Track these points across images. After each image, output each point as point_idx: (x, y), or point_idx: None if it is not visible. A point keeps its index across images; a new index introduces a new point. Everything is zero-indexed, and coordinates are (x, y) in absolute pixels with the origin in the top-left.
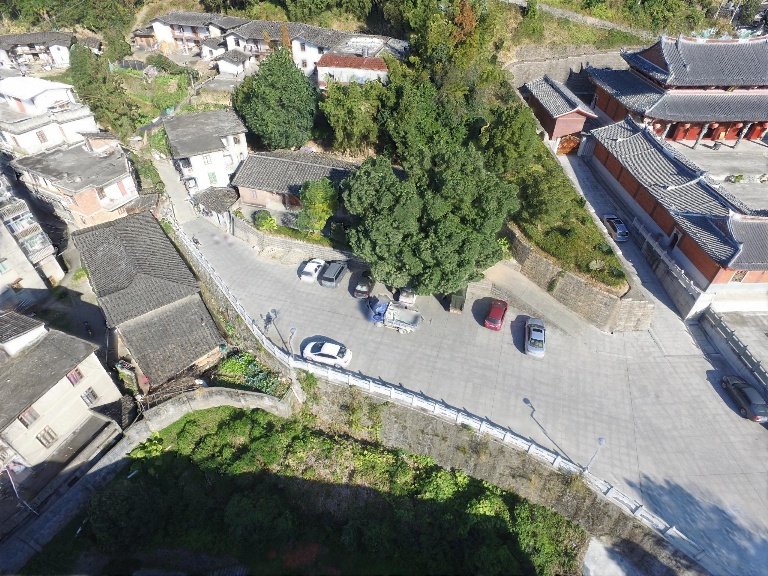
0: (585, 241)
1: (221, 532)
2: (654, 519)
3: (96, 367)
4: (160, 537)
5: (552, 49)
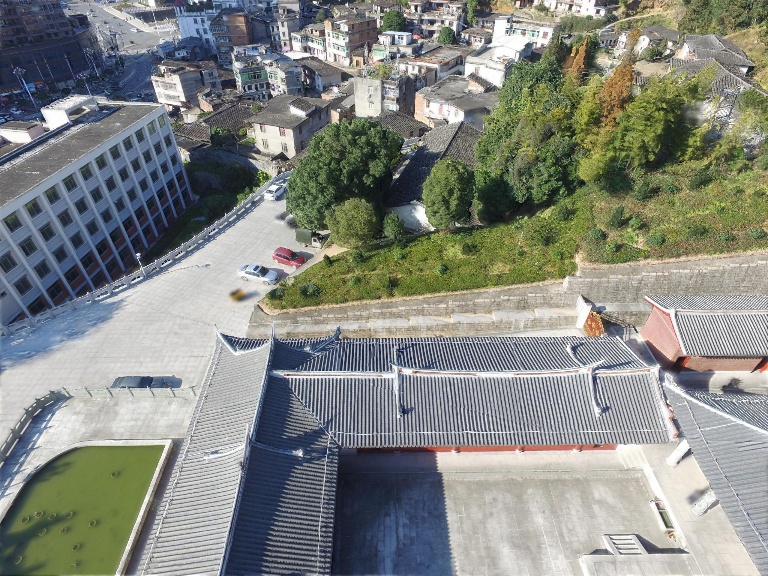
0: None
1: None
2: (99, 291)
3: (291, 138)
4: (228, 195)
5: None
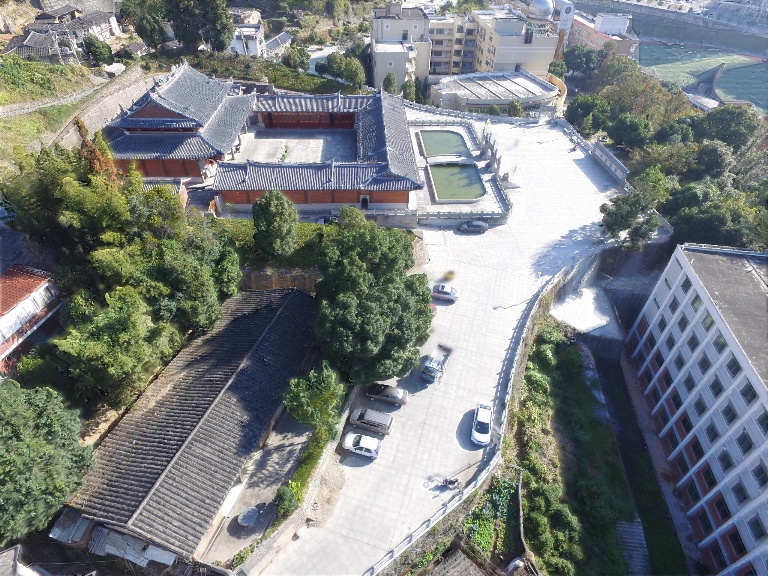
0: None
1: (606, 543)
2: None
3: None
4: None
5: None
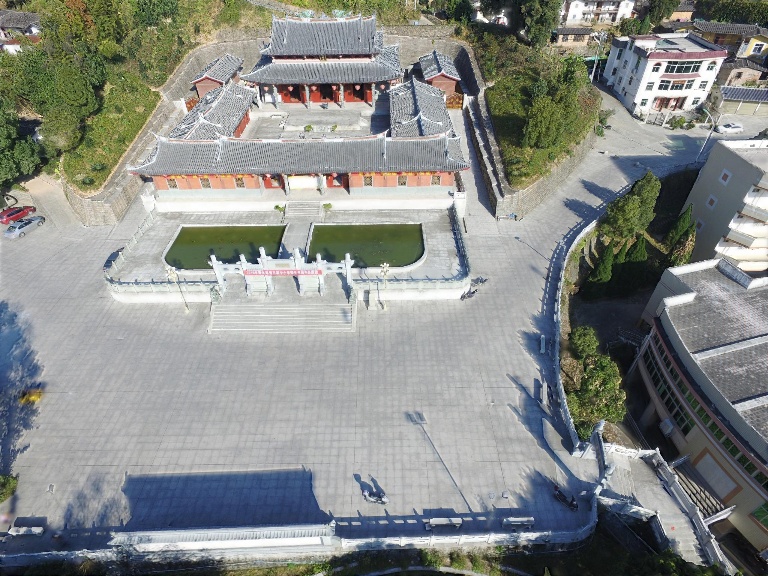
0: (87, 162)
1: None
2: None
3: None
4: None
5: (246, 32)
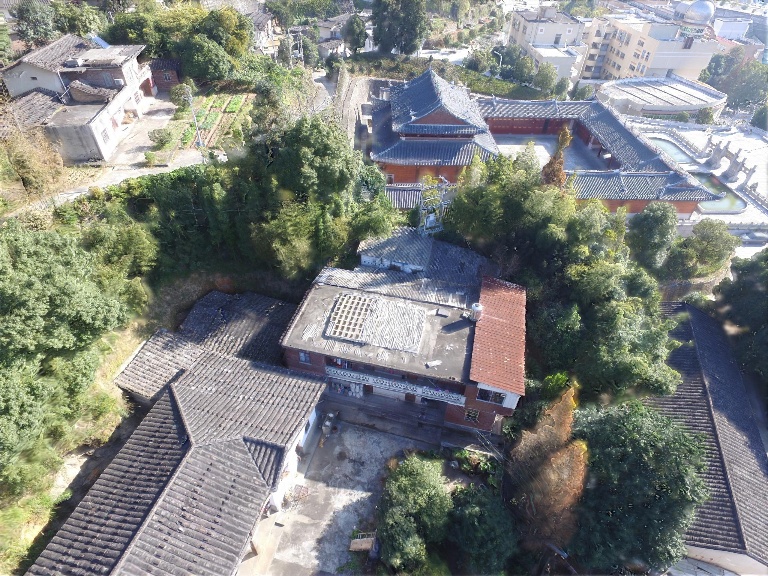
0: None
1: None
2: None
3: None
4: None
5: None
